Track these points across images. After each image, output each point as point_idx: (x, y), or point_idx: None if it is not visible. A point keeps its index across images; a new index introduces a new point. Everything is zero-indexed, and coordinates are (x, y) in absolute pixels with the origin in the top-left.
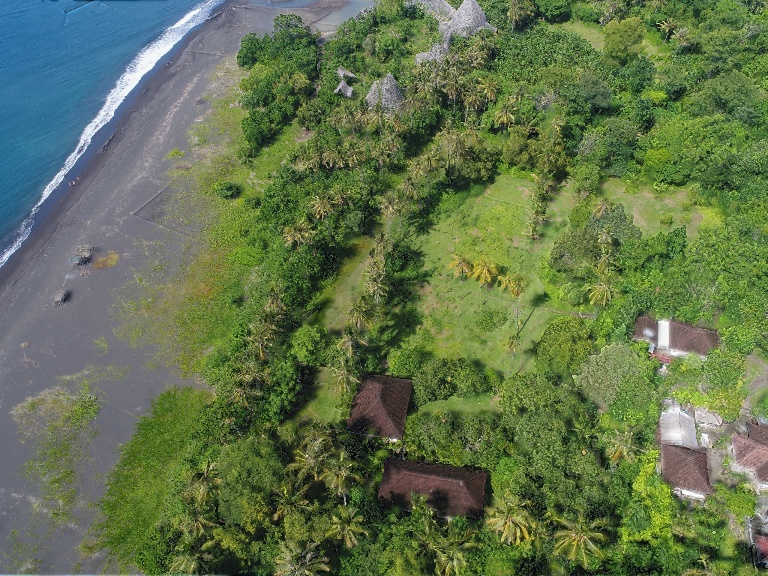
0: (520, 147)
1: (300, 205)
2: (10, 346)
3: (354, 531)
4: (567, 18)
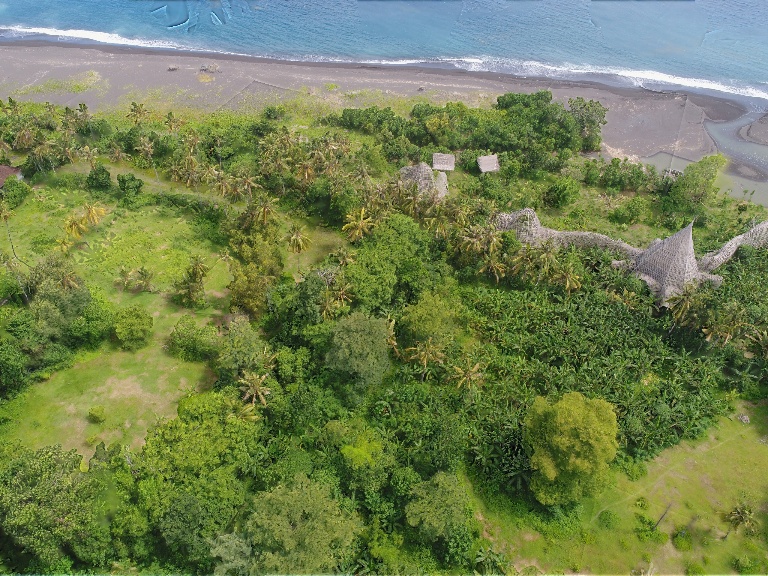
0: None
1: None
2: None
3: None
4: None
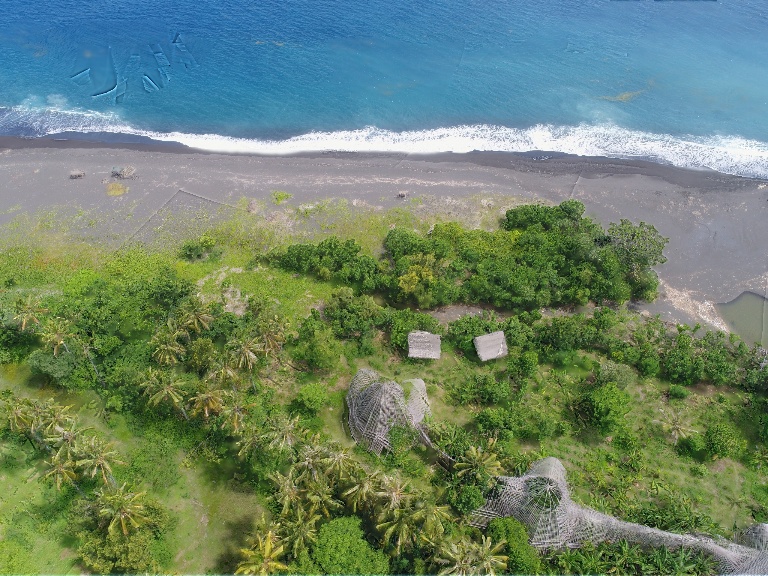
0: None
1: None
2: (42, 165)
3: None
4: None
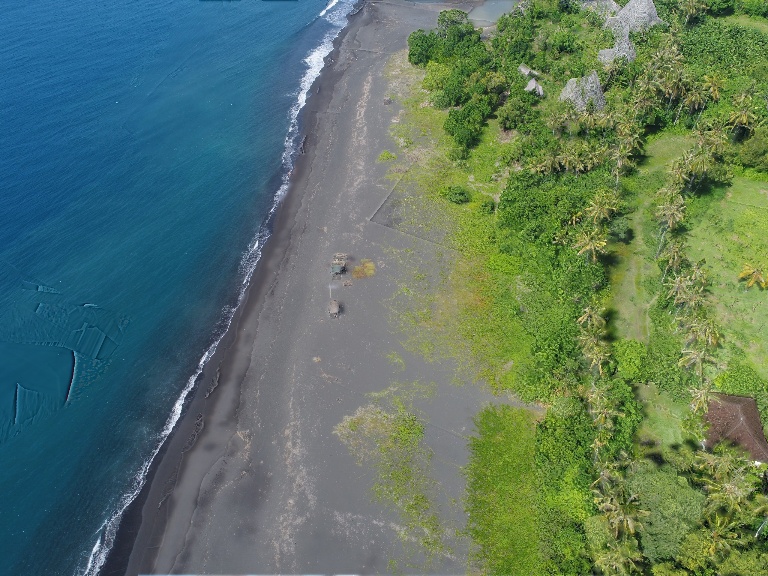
0: (766, 148)
1: (551, 210)
2: (302, 361)
3: None
4: (729, 12)
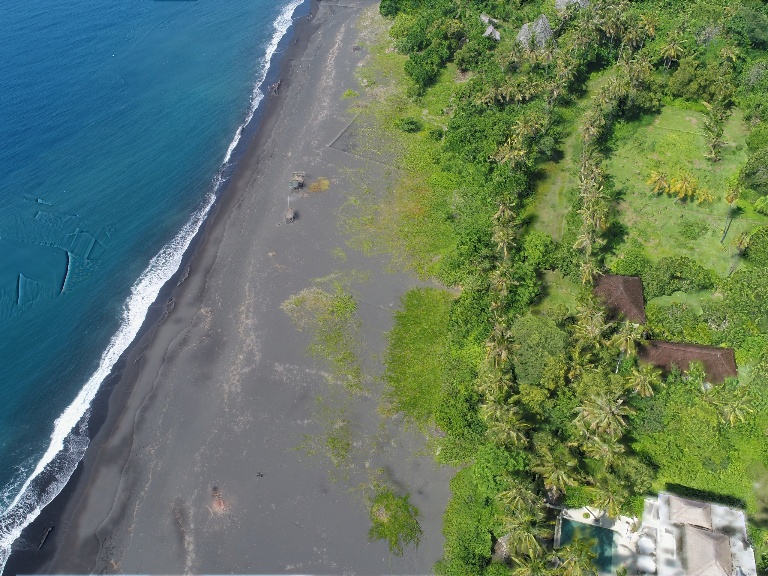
0: (690, 77)
1: (489, 134)
2: (259, 255)
3: (652, 383)
4: None
